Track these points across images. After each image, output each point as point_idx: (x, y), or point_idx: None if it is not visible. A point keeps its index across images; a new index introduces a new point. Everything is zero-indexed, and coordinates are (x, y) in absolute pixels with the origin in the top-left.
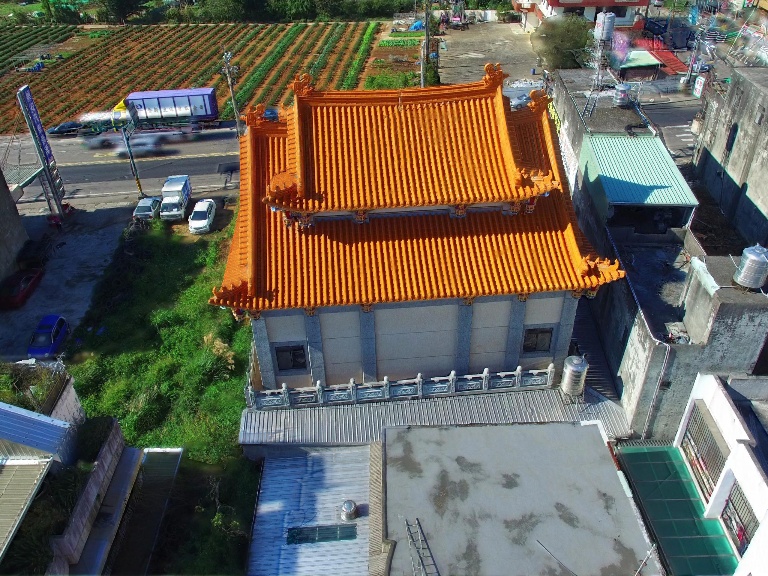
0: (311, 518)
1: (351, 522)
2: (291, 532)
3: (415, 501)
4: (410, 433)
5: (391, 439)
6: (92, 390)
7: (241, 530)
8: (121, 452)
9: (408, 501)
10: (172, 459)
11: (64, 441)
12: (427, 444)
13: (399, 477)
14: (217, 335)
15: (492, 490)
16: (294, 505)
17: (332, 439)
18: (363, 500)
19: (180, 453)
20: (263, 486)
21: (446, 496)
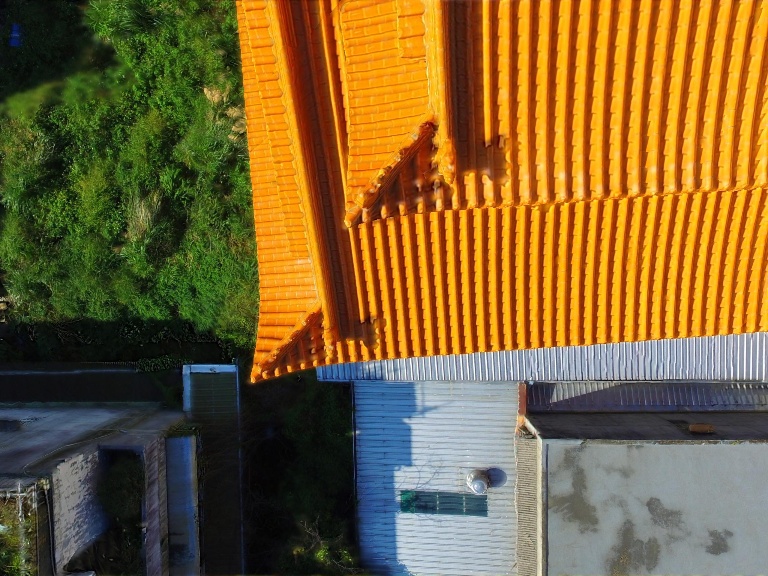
0: (428, 480)
1: (480, 494)
2: (404, 496)
3: (586, 570)
4: (584, 452)
5: (555, 463)
6: (56, 183)
7: (341, 487)
8: (164, 451)
9: (576, 570)
10: (227, 384)
11: (86, 521)
12: (608, 474)
13: (565, 530)
14: (221, 64)
15: (691, 557)
16: (404, 459)
17: (451, 376)
18: (495, 463)
19: (235, 374)
20: (359, 425)
21: (628, 564)
